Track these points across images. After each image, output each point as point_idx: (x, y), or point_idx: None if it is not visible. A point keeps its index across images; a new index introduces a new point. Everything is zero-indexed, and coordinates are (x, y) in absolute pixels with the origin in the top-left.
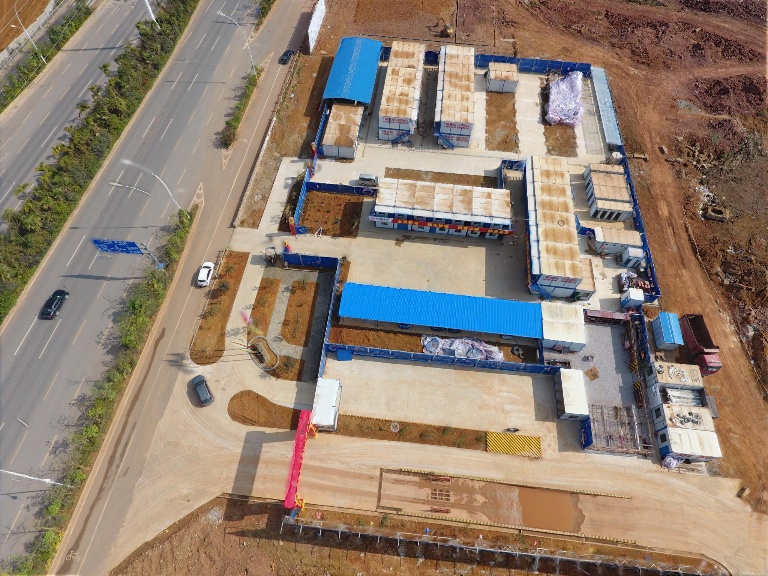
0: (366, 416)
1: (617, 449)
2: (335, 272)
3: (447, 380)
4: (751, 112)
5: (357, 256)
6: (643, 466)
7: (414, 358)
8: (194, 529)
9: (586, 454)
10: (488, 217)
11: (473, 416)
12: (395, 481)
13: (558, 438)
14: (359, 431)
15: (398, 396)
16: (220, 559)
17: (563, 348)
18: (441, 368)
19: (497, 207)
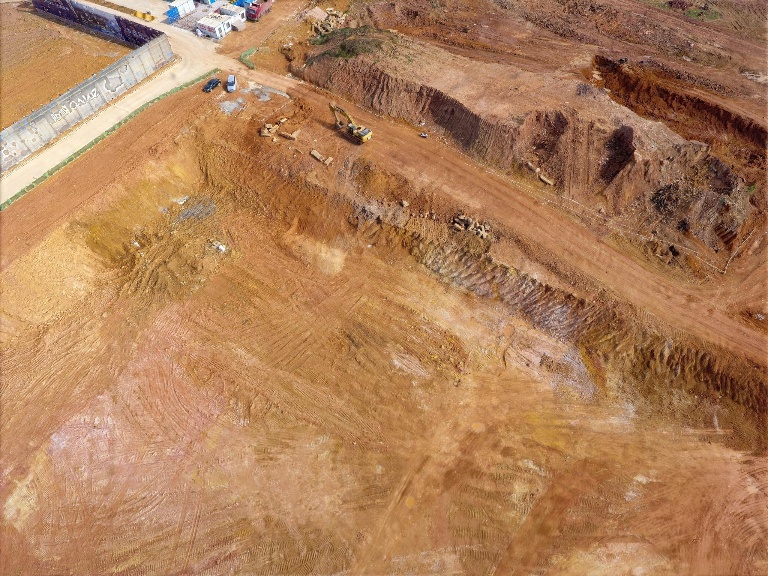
0: None
1: (179, 21)
2: None
3: None
4: None
5: None
6: (188, 33)
7: None
8: (5, 4)
9: (170, 25)
10: None
11: (139, 7)
12: None
13: None
14: None
15: None
16: (6, 11)
17: None
18: None
19: None
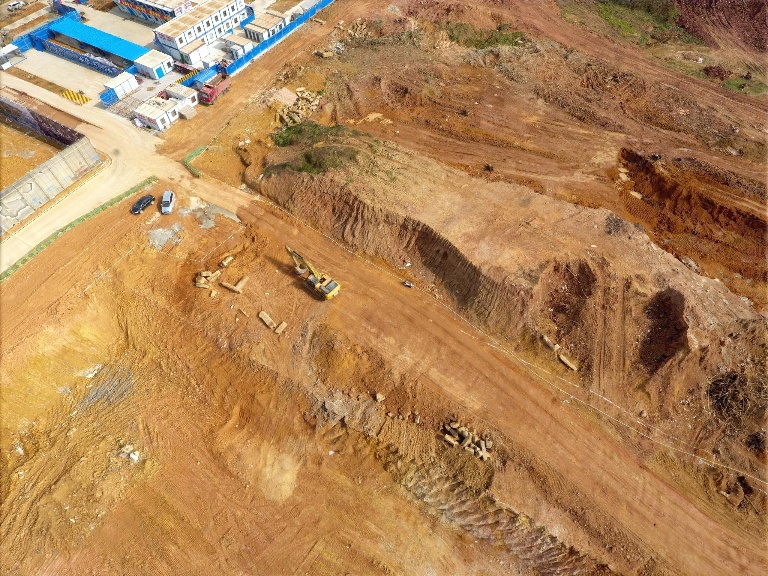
0: (24, 70)
1: (114, 107)
2: (69, 14)
3: (77, 70)
4: (431, 19)
5: (97, 19)
6: (125, 122)
7: (73, 59)
8: None
9: (104, 111)
10: (162, 6)
11: (71, 84)
12: (7, 91)
13: (99, 102)
14: (13, 73)
15: (47, 68)
16: None
17: (146, 73)
18: (80, 65)
19: (172, 3)
